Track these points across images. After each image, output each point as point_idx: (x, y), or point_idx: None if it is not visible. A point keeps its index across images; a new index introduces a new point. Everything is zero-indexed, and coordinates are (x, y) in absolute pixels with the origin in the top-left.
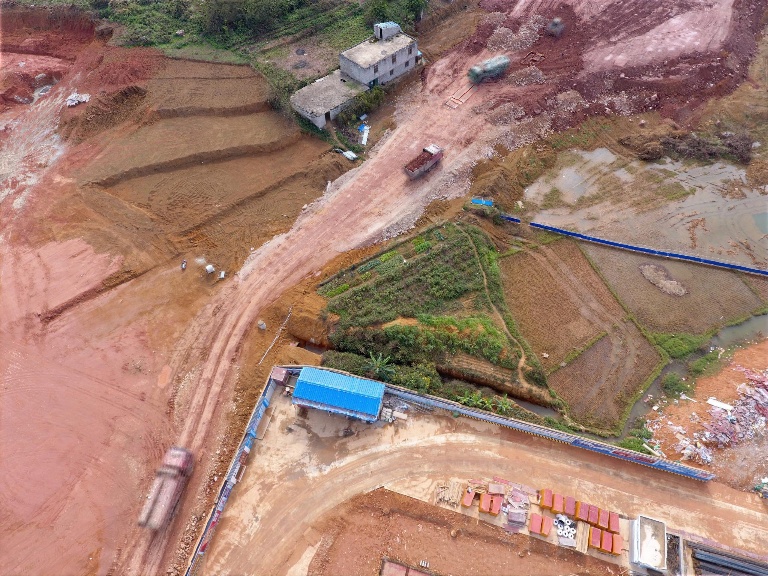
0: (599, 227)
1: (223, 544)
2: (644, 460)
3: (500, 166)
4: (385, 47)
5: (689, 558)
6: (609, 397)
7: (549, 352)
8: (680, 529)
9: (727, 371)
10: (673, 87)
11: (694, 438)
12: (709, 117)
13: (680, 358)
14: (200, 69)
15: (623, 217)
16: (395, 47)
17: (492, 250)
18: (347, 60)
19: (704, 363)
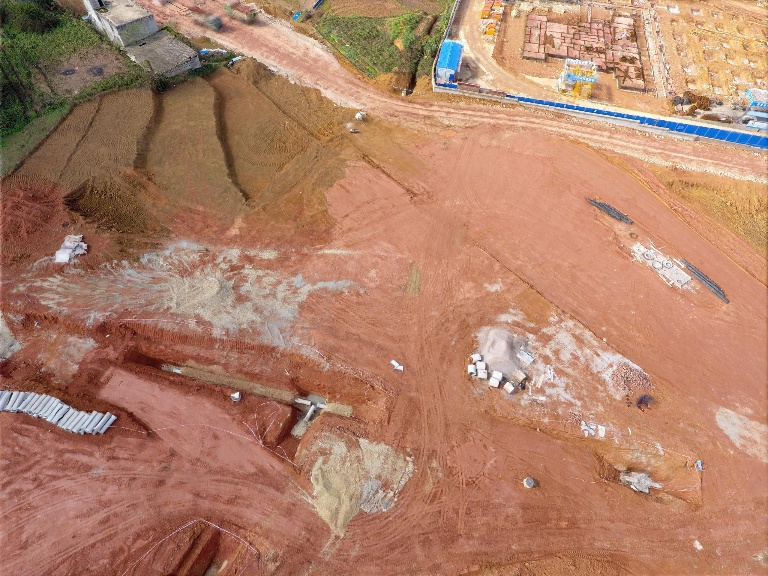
0: None
1: None
2: None
3: None
4: (120, 5)
5: None
6: (428, 3)
7: None
8: None
9: None
10: None
11: None
12: None
13: None
14: (60, 142)
15: None
16: (123, 0)
17: None
18: (129, 25)
19: None
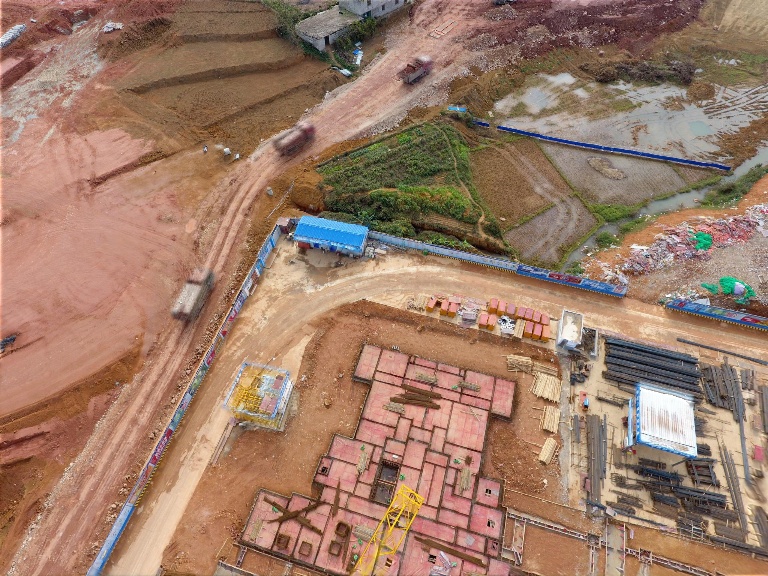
0: (556, 130)
1: (239, 334)
2: (573, 280)
3: (474, 83)
4: None
5: (602, 344)
6: (552, 247)
7: (506, 217)
8: (598, 327)
9: (650, 228)
10: (629, 23)
11: (615, 268)
12: (660, 49)
13: (614, 221)
14: (217, 5)
15: (577, 123)
16: None
17: (463, 145)
18: None
19: (633, 224)
